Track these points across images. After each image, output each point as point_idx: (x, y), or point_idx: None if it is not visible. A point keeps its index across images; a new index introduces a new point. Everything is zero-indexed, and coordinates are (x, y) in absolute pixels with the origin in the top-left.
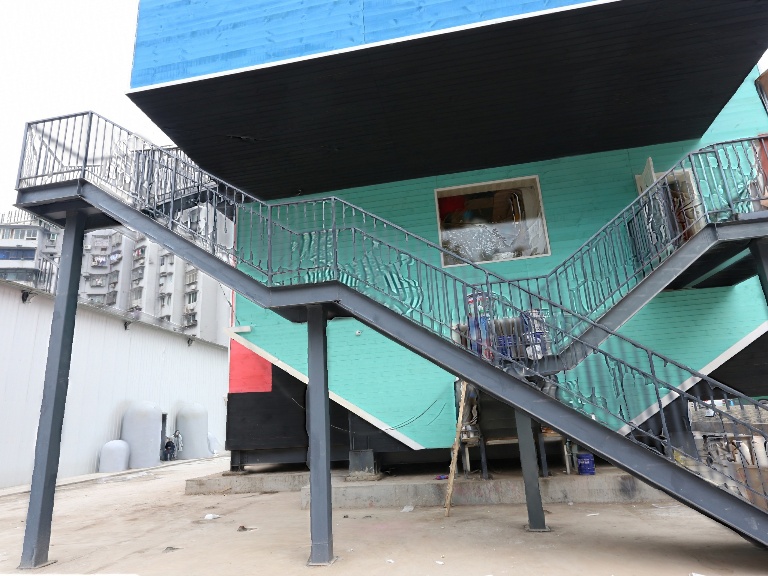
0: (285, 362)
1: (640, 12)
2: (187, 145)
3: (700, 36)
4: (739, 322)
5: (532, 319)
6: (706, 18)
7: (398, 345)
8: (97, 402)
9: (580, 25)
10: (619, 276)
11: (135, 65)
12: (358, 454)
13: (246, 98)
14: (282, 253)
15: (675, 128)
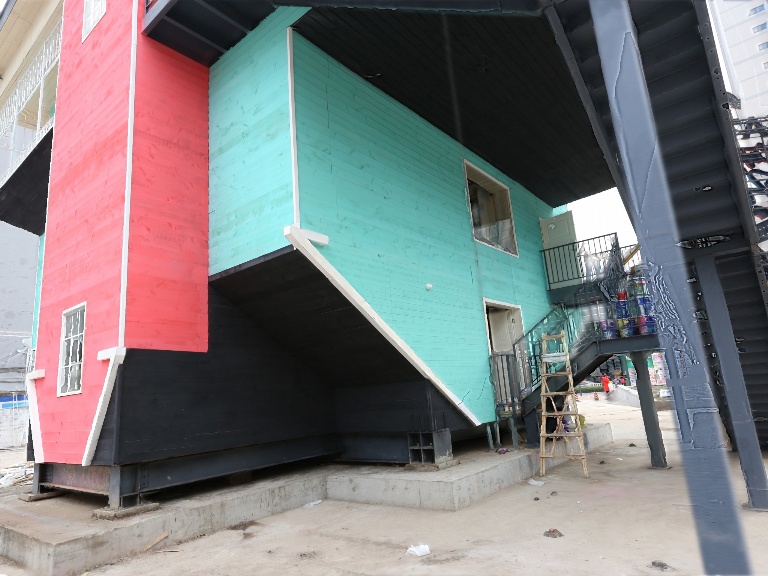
0: (370, 305)
1: None
2: None
3: None
4: None
5: None
6: None
7: (455, 310)
8: None
9: None
10: None
11: None
12: (441, 435)
13: None
14: (352, 145)
15: (561, 196)
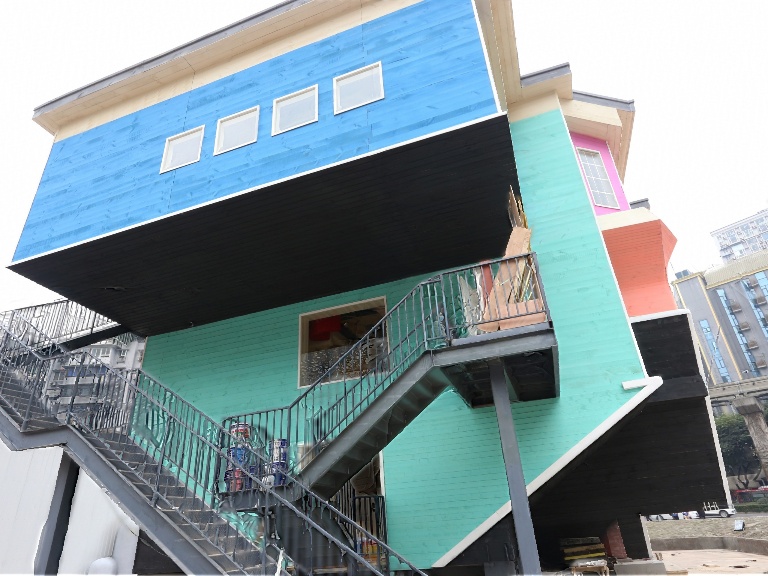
0: None
1: (370, 168)
2: (75, 297)
3: (442, 177)
4: (563, 436)
5: (272, 449)
6: (434, 165)
7: None
8: (91, 518)
9: (327, 183)
10: (348, 405)
11: (20, 243)
12: None
13: (97, 261)
14: (173, 380)
15: (495, 245)
